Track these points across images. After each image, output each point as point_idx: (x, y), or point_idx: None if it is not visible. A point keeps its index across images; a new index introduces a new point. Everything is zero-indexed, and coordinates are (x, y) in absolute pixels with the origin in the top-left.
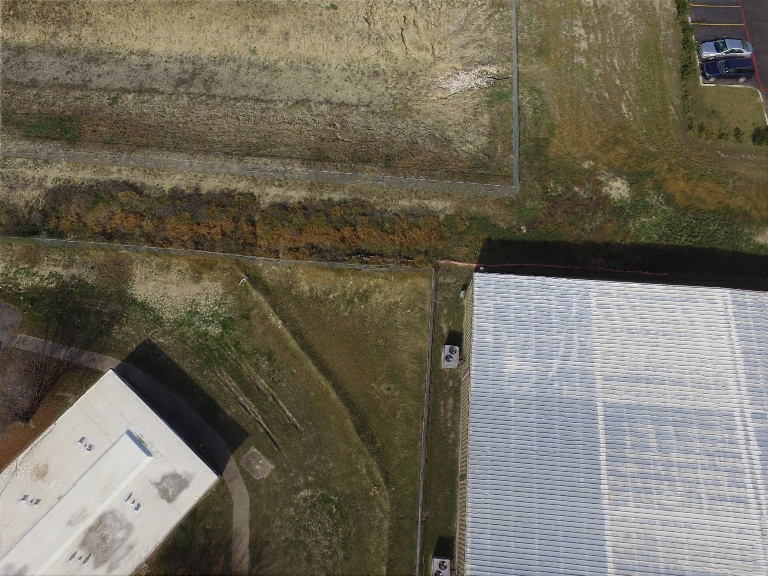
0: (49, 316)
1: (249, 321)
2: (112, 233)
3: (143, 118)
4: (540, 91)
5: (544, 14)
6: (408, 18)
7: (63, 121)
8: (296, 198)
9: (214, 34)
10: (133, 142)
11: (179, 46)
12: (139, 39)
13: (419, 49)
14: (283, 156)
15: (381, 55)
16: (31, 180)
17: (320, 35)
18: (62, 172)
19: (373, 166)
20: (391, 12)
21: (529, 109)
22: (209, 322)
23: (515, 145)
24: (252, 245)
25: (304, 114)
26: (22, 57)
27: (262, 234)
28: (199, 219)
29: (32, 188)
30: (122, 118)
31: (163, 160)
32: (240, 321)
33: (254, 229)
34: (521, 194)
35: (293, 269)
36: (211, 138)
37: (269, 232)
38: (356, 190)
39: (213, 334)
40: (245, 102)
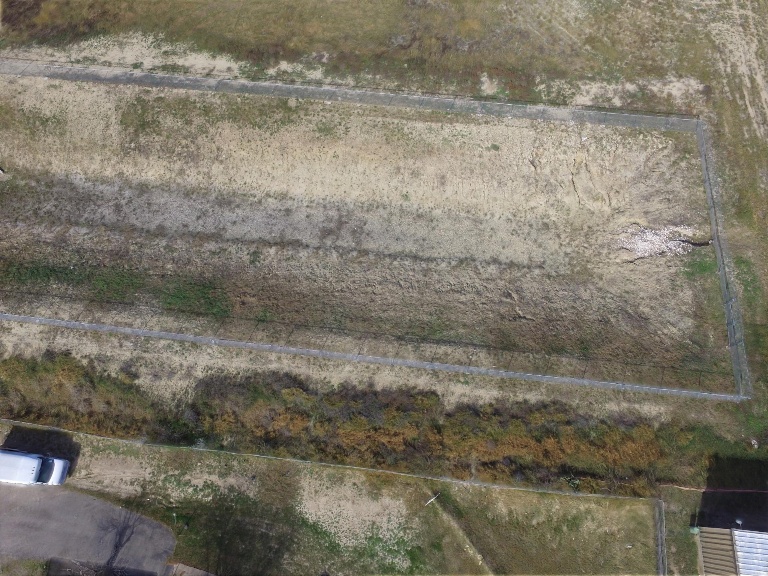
0: (208, 540)
1: (442, 553)
2: (276, 438)
3: (293, 283)
4: (748, 263)
5: (737, 163)
6: (577, 160)
7: (205, 287)
8: (486, 399)
9: (361, 176)
10: (290, 320)
11: (321, 188)
12: (276, 179)
13: (594, 199)
14: (464, 342)
15: (551, 205)
16: (178, 368)
17: (481, 180)
18: (214, 359)
19: (570, 358)
20: (560, 154)
21: (739, 286)
22: (395, 553)
23: (730, 333)
24: (440, 457)
25: (472, 278)
26: (146, 197)
27: (451, 445)
28: (376, 423)
29: (180, 377)
30: (269, 283)
31: (328, 346)
32: (431, 553)
33: (441, 438)
34: (746, 398)
35: (488, 488)
36: (376, 314)
37: (460, 443)
38: (554, 390)
39: (401, 569)
40: (402, 260)
